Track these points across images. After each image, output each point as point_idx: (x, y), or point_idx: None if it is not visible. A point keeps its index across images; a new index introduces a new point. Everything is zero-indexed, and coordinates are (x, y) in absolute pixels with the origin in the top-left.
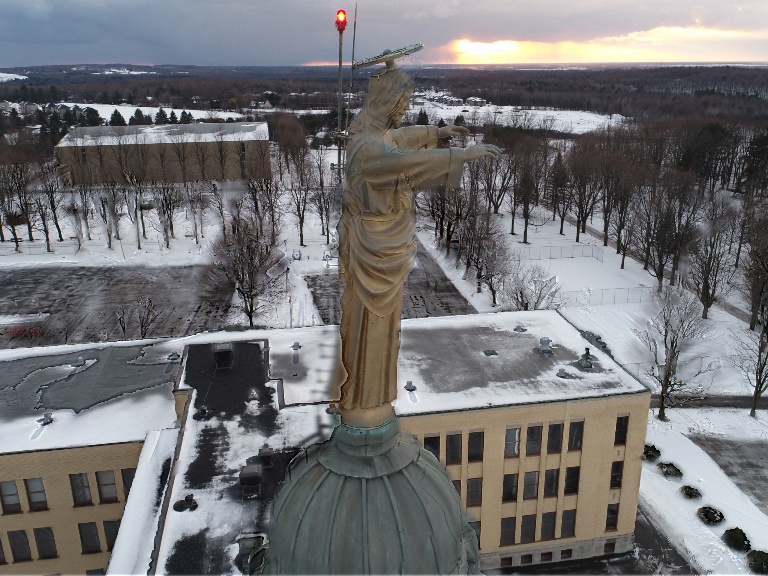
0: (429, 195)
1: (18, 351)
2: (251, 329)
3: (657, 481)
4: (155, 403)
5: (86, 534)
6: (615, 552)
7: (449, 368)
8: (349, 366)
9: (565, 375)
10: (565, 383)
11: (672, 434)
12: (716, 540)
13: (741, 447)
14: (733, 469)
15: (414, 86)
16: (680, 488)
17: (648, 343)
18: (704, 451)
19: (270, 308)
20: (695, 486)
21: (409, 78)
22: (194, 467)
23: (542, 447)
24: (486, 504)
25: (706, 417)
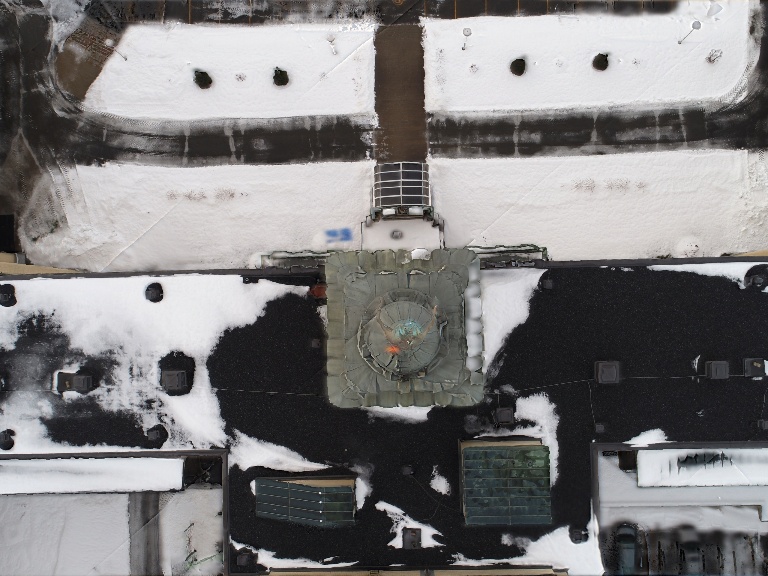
0: None
1: None
2: None
3: None
4: None
5: None
6: None
7: None
8: None
9: None
10: None
11: None
12: None
13: None
14: None
15: None
16: None
17: None
18: None
19: None
20: None
21: None
22: None
23: None
24: None
25: None
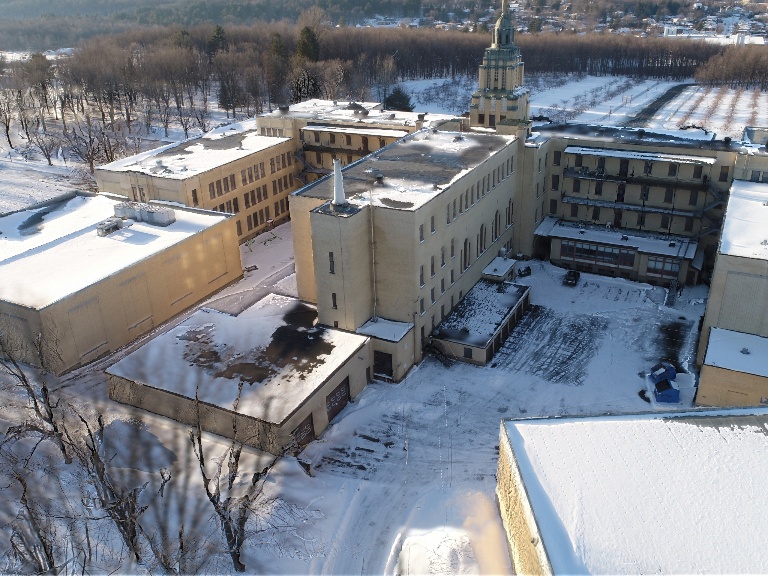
0: (97, 93)
1: (156, 150)
2: None
3: None
4: None
5: None
6: None
7: None
8: None
9: None
10: None
11: None
12: None
13: None
14: None
15: None
16: None
17: None
18: None
19: None
20: None
21: None
22: None
23: None
24: None
25: None
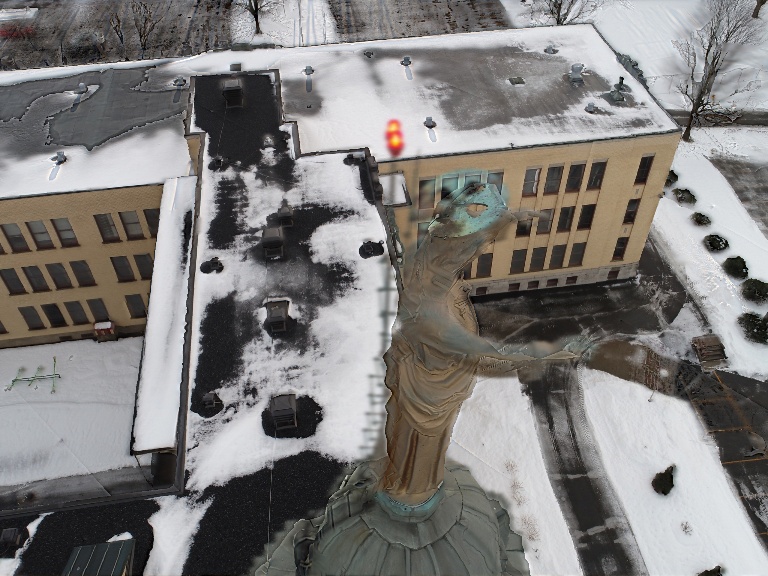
0: None
1: (15, 74)
2: (259, 48)
3: (670, 207)
4: (167, 139)
5: (119, 266)
6: (618, 278)
7: (471, 100)
8: (395, 466)
9: (594, 110)
10: (593, 120)
11: (694, 156)
12: (716, 267)
13: (761, 170)
14: (748, 194)
15: (491, 237)
16: (691, 215)
17: (687, 57)
18: (723, 175)
19: (276, 6)
20: (706, 212)
21: (486, 236)
22: (216, 225)
23: (561, 186)
24: (500, 238)
25: (732, 137)
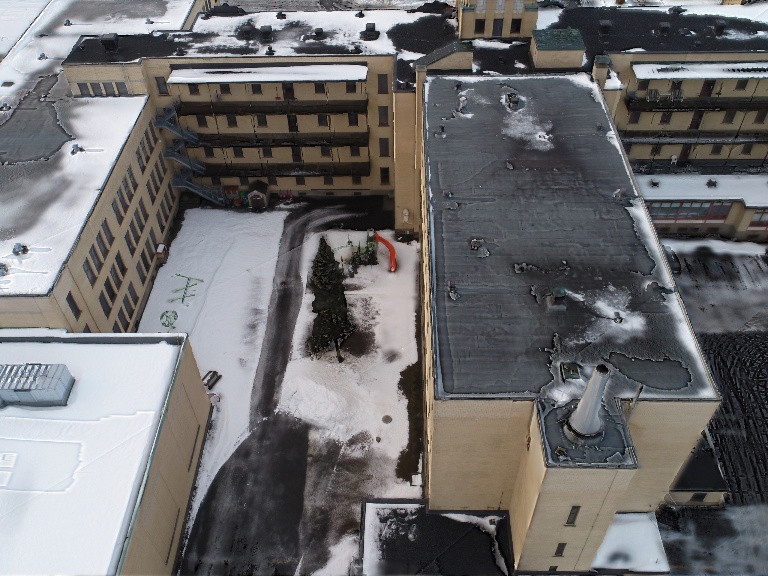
0: None
1: None
2: None
3: None
4: (89, 108)
5: None
6: None
7: (134, 9)
8: None
9: None
10: None
11: None
12: None
13: None
14: None
15: None
16: None
17: None
18: None
19: None
20: None
21: None
22: (237, 53)
23: None
24: None
25: None
